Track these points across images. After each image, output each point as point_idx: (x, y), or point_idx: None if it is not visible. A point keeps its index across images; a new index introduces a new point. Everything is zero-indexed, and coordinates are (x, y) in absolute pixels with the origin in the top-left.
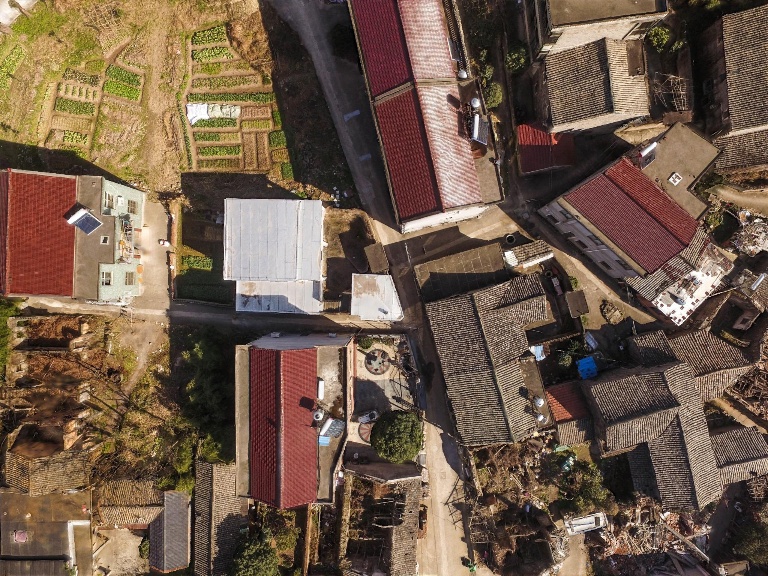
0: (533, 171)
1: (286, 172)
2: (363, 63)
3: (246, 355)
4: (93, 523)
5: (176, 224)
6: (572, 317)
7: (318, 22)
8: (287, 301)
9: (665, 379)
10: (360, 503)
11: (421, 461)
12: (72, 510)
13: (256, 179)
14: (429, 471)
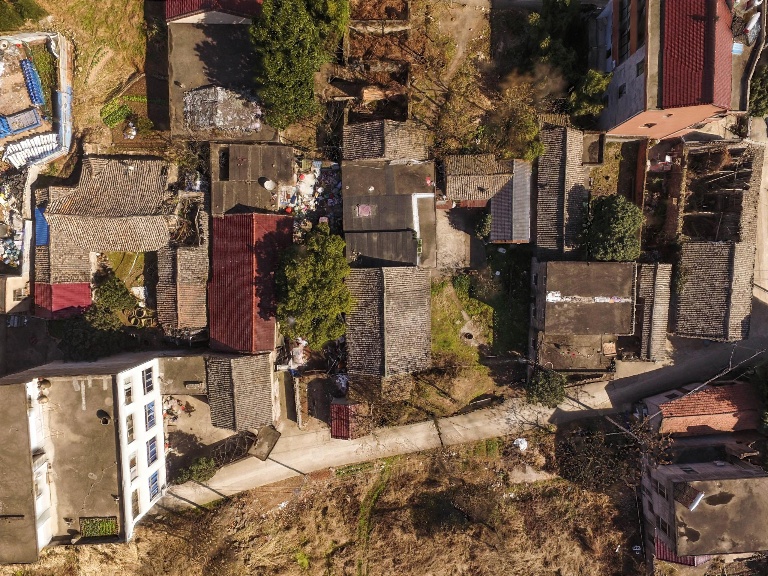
0: None
1: None
2: None
3: None
4: (436, 197)
5: None
6: None
7: None
8: None
9: None
10: (687, 187)
11: None
12: (416, 182)
13: None
14: None
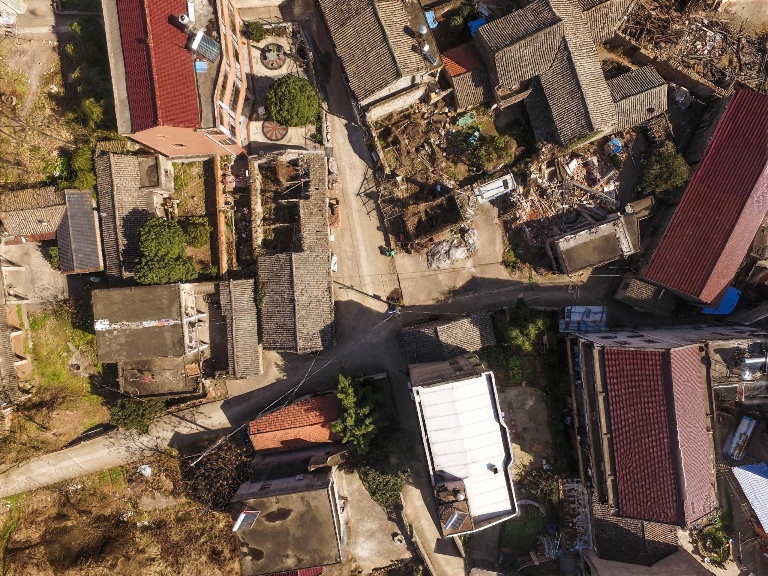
0: None
1: None
2: None
3: None
4: None
5: None
6: None
7: None
8: None
9: None
10: (271, 200)
11: (328, 154)
12: None
13: None
14: (338, 164)
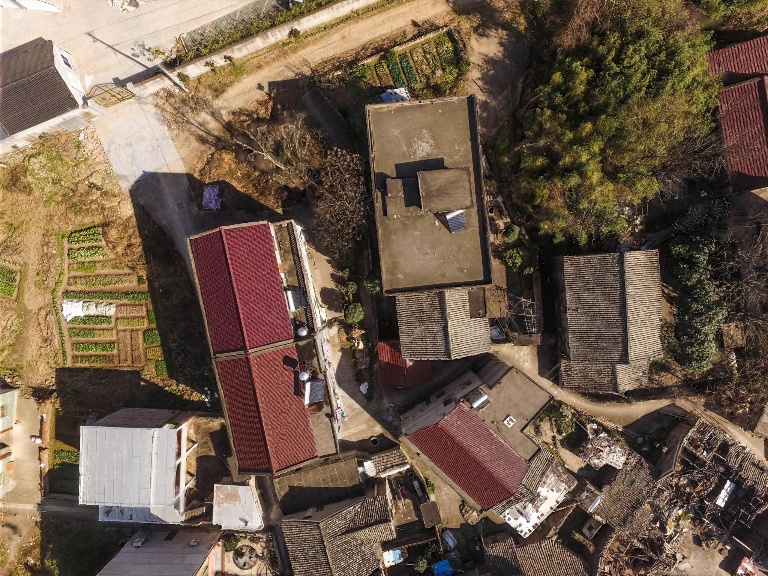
0: None
1: (160, 369)
2: (206, 319)
3: None
4: None
5: (48, 420)
6: None
7: (192, 227)
8: (149, 511)
9: None
10: None
11: None
12: None
13: (130, 376)
14: None
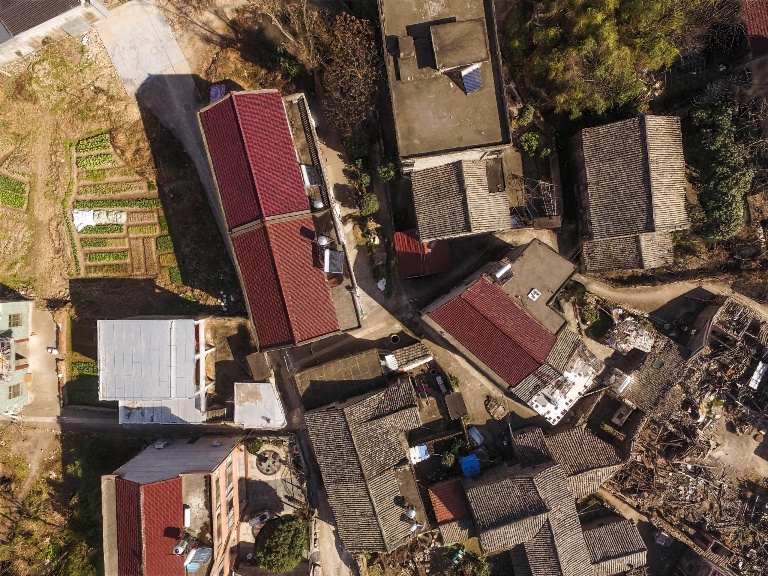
0: (410, 277)
1: (174, 276)
2: (220, 195)
3: (113, 485)
4: None
5: (64, 331)
6: (452, 419)
7: None
8: (170, 412)
9: (534, 485)
10: None
11: (315, 558)
12: None
13: (144, 284)
14: (323, 568)
